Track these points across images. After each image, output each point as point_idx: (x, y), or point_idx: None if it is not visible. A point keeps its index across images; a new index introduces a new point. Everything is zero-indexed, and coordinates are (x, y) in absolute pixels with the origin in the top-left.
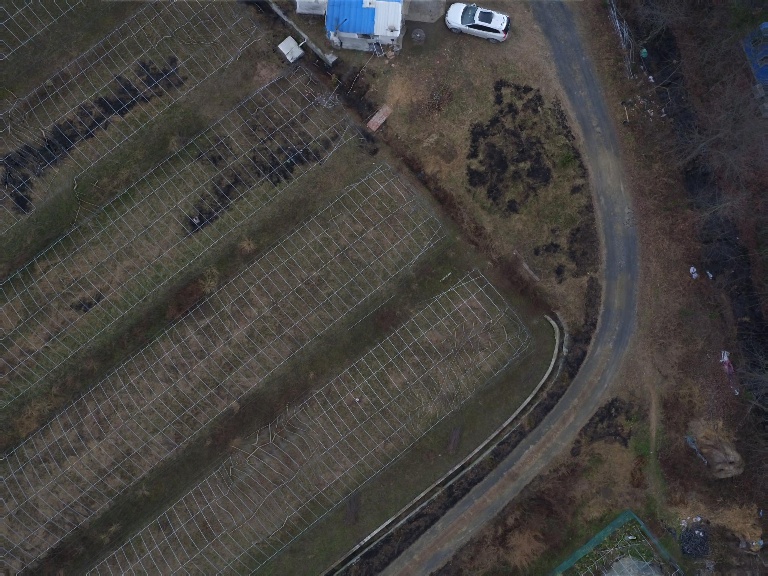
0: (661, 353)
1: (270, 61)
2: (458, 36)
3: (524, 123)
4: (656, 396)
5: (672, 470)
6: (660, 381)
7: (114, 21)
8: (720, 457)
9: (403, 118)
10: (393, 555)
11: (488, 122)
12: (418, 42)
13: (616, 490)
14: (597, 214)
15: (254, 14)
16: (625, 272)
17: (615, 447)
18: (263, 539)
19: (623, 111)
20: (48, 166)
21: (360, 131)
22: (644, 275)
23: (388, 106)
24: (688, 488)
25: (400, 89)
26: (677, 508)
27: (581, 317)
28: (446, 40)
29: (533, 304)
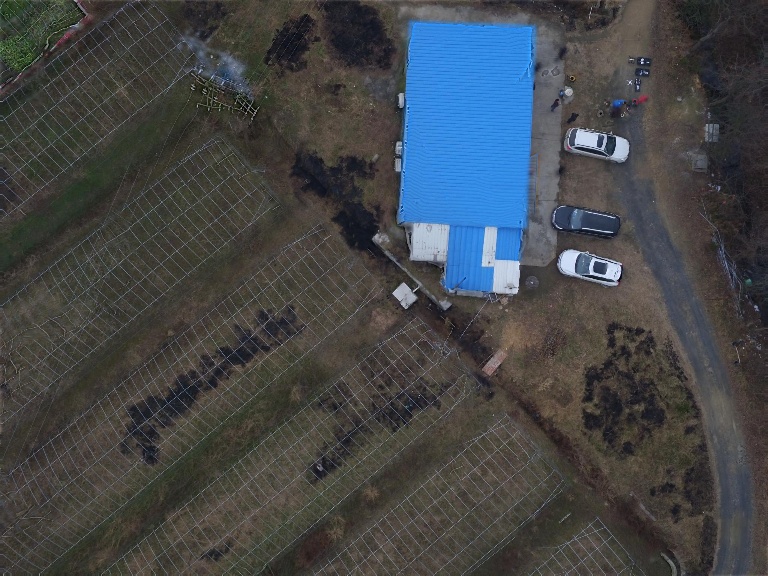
0: None
1: (384, 308)
2: (570, 280)
3: (637, 365)
4: None
5: None
6: None
7: (231, 277)
8: None
9: (518, 363)
10: None
11: (602, 365)
12: (532, 288)
13: None
14: (710, 453)
15: (367, 261)
16: (739, 510)
17: None
18: None
19: (734, 351)
20: None
21: (476, 378)
22: (758, 512)
23: (503, 351)
24: None
25: (514, 334)
26: None
27: (698, 556)
28: (558, 283)
29: (651, 547)
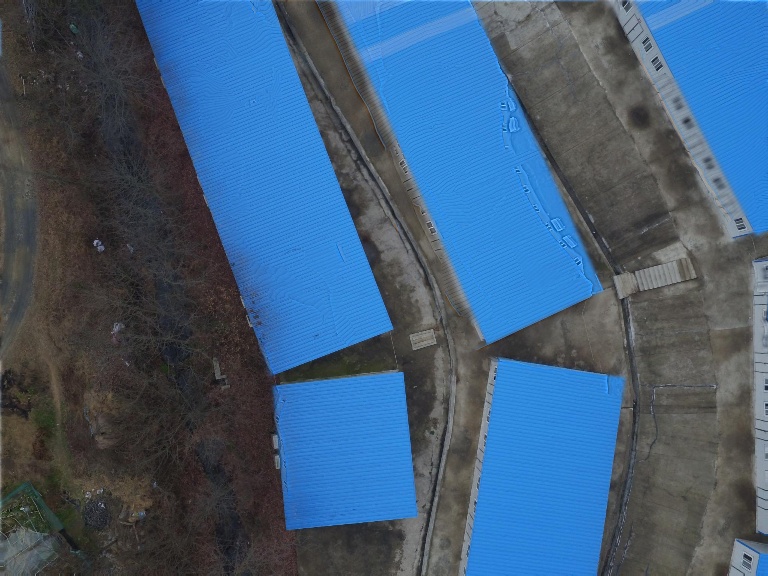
0: (56, 325)
1: None
2: None
3: None
4: (54, 368)
5: (77, 442)
6: (55, 353)
7: None
8: (94, 428)
9: None
10: None
11: None
12: None
13: (18, 462)
14: None
15: None
16: (23, 244)
17: (13, 419)
18: None
19: (21, 83)
20: None
21: None
22: (42, 247)
23: None
24: (91, 460)
25: None
26: (82, 480)
27: None
28: None
29: None
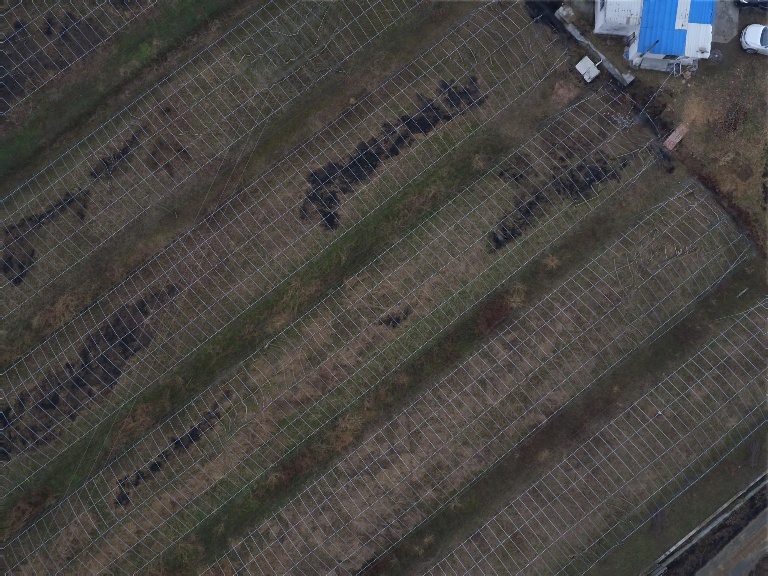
0: None
1: (567, 81)
2: (751, 56)
3: None
4: None
5: None
6: None
7: (420, 41)
8: None
9: (700, 137)
10: (698, 566)
11: None
12: (715, 62)
13: None
14: None
15: (550, 34)
16: None
17: None
18: (579, 552)
19: None
20: (584, 203)
21: (659, 150)
22: None
23: (684, 125)
24: None
25: (696, 109)
26: None
27: None
28: (739, 60)
29: None
